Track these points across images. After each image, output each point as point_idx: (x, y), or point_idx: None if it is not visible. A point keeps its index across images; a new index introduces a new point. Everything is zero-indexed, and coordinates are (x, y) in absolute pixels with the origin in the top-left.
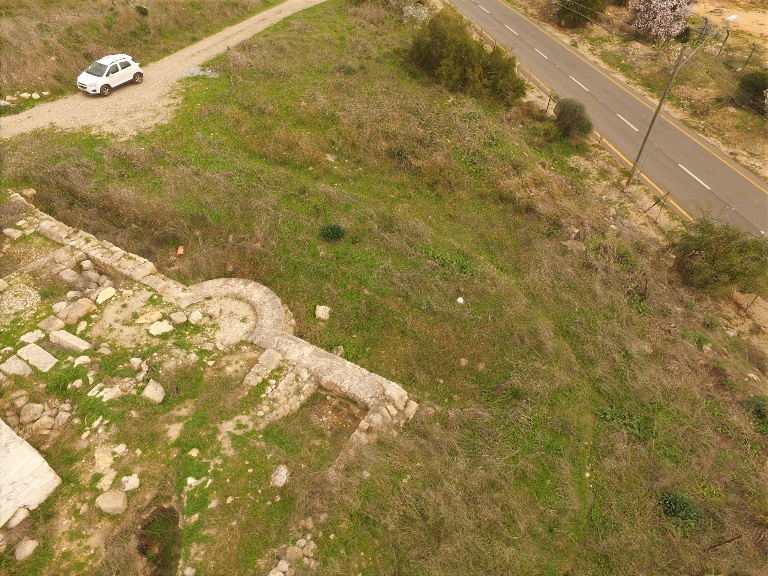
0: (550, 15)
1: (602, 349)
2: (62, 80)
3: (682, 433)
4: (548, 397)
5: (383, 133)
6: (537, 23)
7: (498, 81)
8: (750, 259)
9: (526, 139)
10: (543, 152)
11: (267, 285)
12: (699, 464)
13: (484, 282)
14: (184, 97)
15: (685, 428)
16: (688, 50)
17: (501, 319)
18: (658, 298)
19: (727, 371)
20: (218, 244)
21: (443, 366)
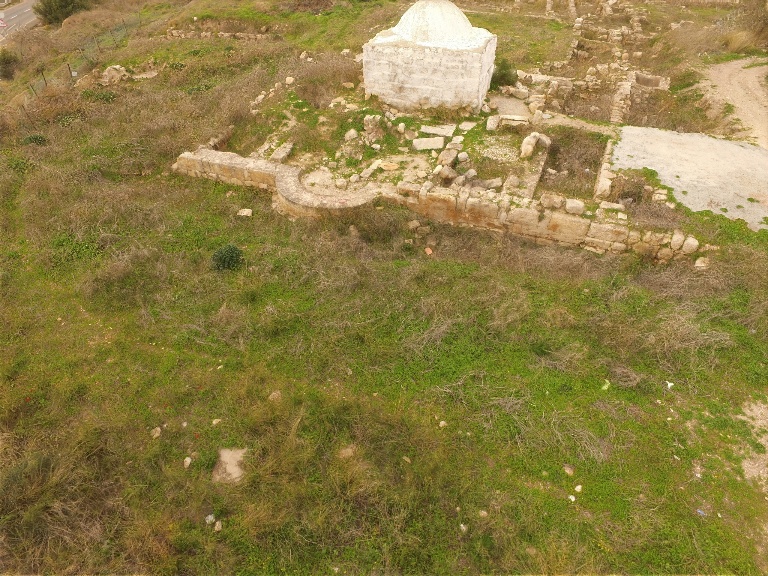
0: None
1: None
2: None
3: None
4: None
5: None
6: None
7: None
8: None
9: None
10: None
11: None
12: None
13: None
14: None
15: None
16: None
17: (63, 206)
18: None
19: None
20: None
21: None
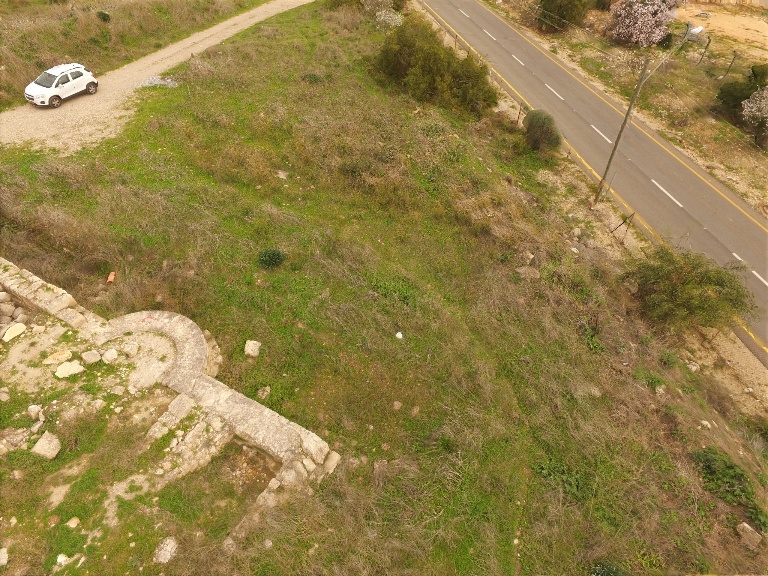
0: (531, 19)
1: (545, 393)
2: (10, 91)
3: (624, 491)
4: (481, 449)
5: (340, 148)
6: (517, 28)
7: (468, 90)
8: (710, 291)
9: (494, 152)
10: (511, 166)
11: (197, 317)
12: (640, 528)
13: (427, 314)
14: (138, 108)
15: (628, 485)
16: (652, 63)
17: (441, 357)
18: (612, 332)
19: (678, 419)
20: (150, 271)
21: (375, 410)
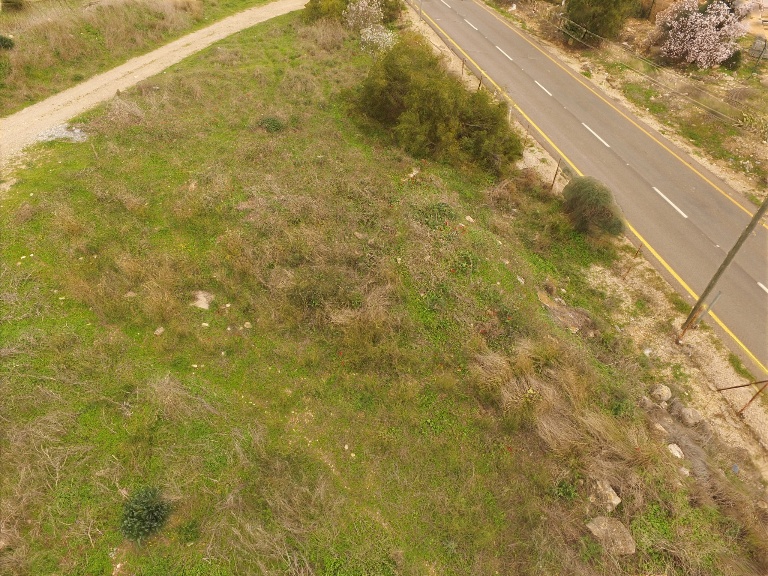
0: (554, 31)
1: None
2: None
3: None
4: None
5: None
6: (538, 43)
7: (483, 140)
8: None
9: (522, 236)
10: (548, 259)
11: None
12: None
13: None
14: (17, 180)
15: None
16: None
17: None
18: None
19: None
20: None
21: None
